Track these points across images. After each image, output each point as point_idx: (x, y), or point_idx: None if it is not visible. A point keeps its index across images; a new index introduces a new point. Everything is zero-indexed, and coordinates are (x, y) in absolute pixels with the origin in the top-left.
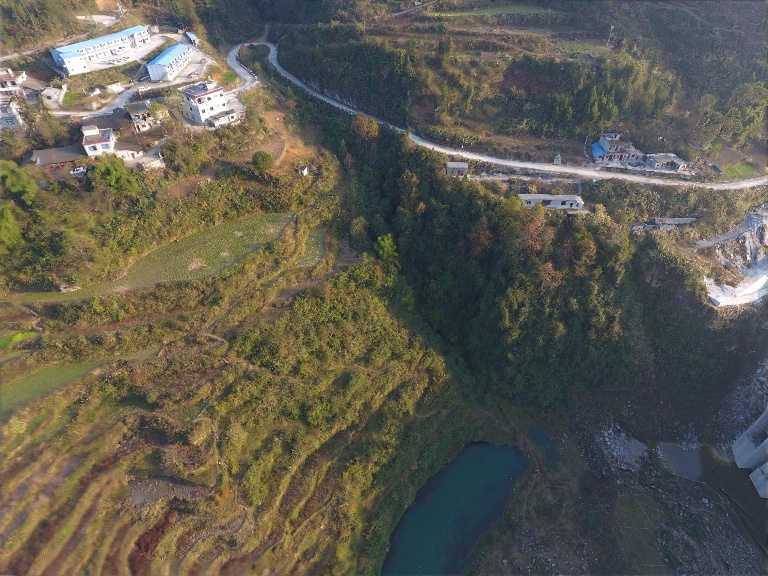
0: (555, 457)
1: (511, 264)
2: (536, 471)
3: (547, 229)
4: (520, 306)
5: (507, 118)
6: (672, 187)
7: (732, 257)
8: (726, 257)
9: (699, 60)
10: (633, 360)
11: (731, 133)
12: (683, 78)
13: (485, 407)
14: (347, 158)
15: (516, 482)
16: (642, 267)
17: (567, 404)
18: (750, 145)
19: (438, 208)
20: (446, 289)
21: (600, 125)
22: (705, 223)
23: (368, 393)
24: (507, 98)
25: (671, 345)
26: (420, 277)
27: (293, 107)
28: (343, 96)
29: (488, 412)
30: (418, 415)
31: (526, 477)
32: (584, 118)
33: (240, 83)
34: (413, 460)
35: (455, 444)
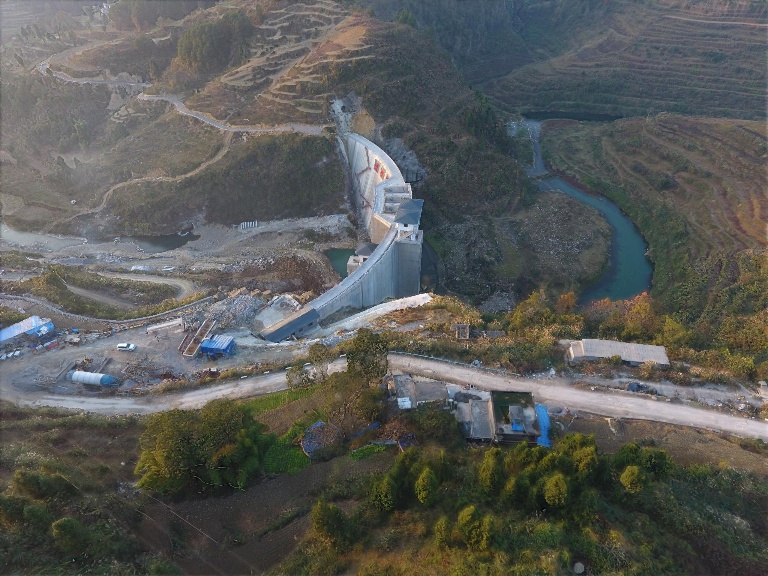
0: None
1: None
2: None
3: None
4: None
5: None
6: None
7: None
8: None
9: None
10: None
11: None
12: None
13: None
14: None
15: None
16: None
17: None
18: None
19: None
20: None
21: None
22: None
23: None
24: None
25: None
26: None
27: None
28: None
29: None
30: None
31: None
32: None
33: None
34: None
35: None
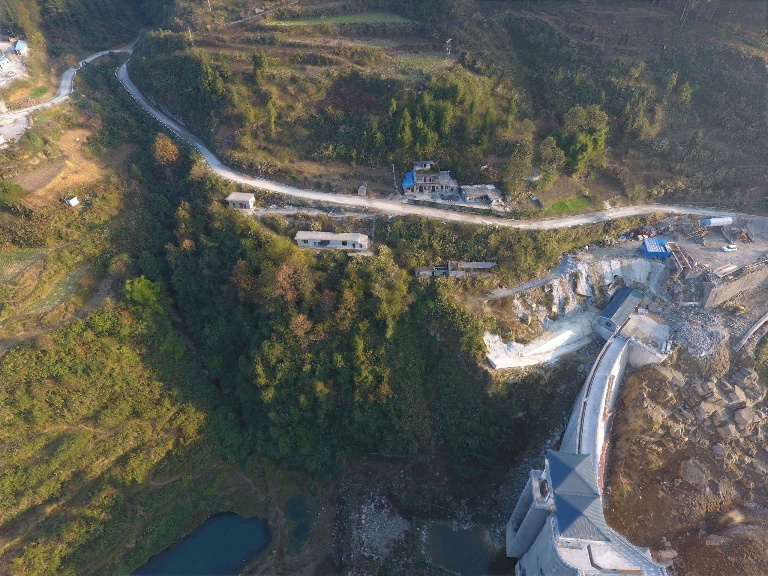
0: (303, 535)
1: (269, 314)
2: (272, 552)
3: (309, 275)
4: (279, 361)
5: (315, 142)
6: (472, 226)
7: (534, 308)
8: (527, 308)
9: (552, 76)
10: (404, 425)
11: (553, 164)
12: (537, 96)
13: (244, 471)
14: (132, 185)
15: (246, 565)
16: (418, 320)
17: (333, 472)
18: (595, 174)
19: (205, 246)
20: (221, 335)
21: (418, 151)
22: (506, 268)
23: (84, 460)
24: (324, 119)
25: (449, 409)
26: (199, 320)
27: (98, 126)
28: (172, 112)
29: (246, 477)
30: (153, 482)
31: (260, 559)
32: (395, 144)
33: (48, 99)
34: (130, 537)
35: (196, 515)
